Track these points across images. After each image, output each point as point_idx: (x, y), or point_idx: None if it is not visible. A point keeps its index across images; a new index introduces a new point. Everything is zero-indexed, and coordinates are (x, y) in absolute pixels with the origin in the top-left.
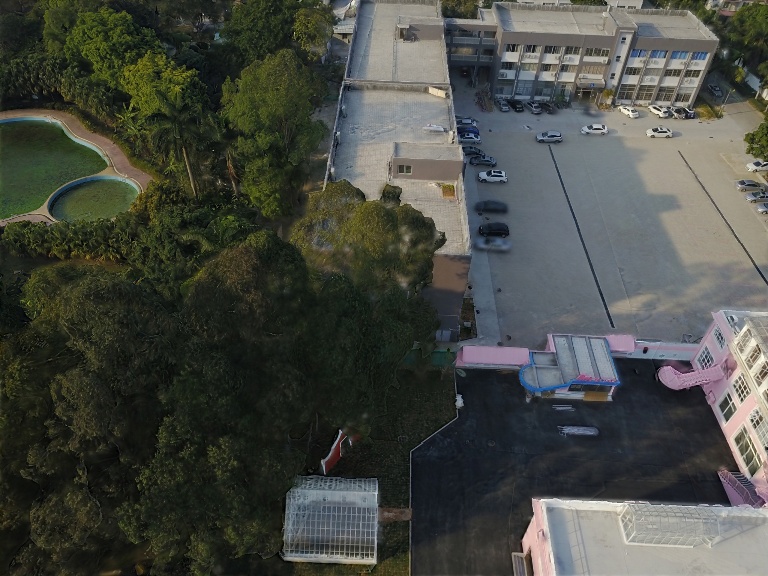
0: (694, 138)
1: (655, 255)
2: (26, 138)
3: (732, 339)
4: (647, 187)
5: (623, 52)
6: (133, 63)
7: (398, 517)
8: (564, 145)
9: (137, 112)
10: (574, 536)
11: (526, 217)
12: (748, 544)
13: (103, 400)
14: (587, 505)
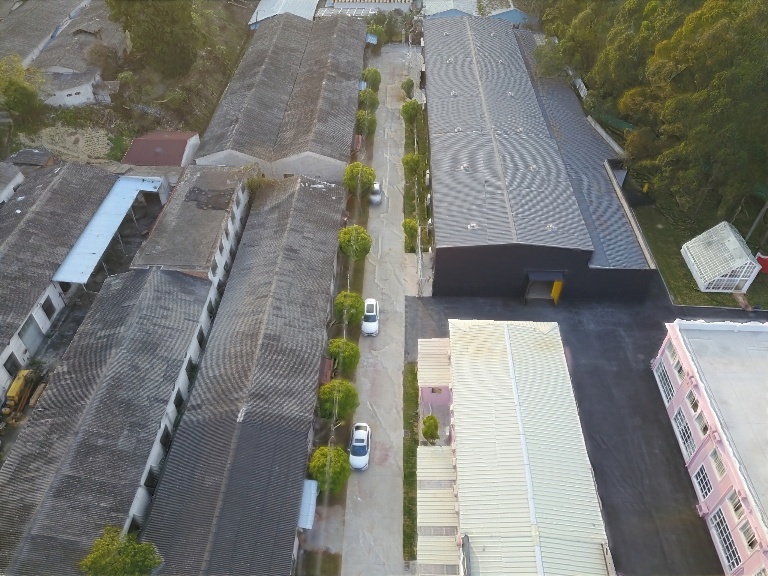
0: None
1: None
2: None
3: None
4: None
5: None
6: None
7: (742, 304)
8: None
9: None
10: None
11: None
12: None
13: (718, 35)
14: None
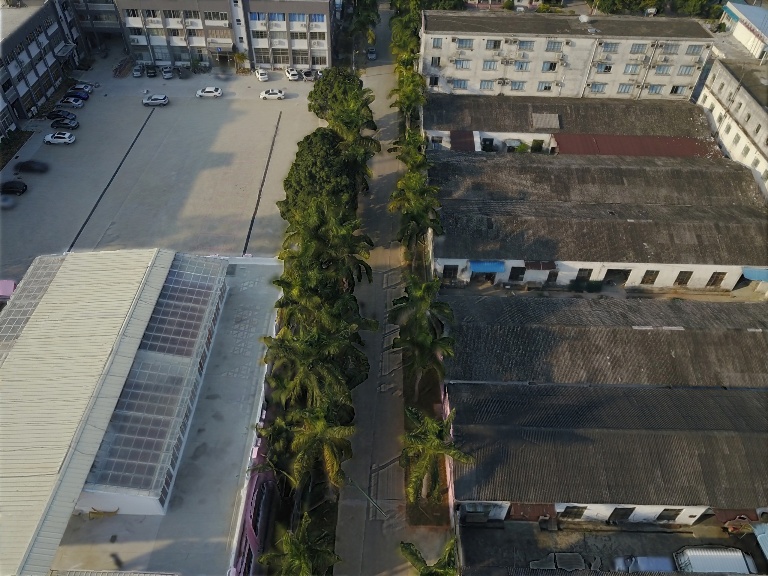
0: None
1: (159, 209)
2: None
3: None
4: (213, 146)
5: (240, 15)
6: None
7: None
8: (168, 108)
9: None
10: None
11: (63, 176)
12: None
13: None
14: None
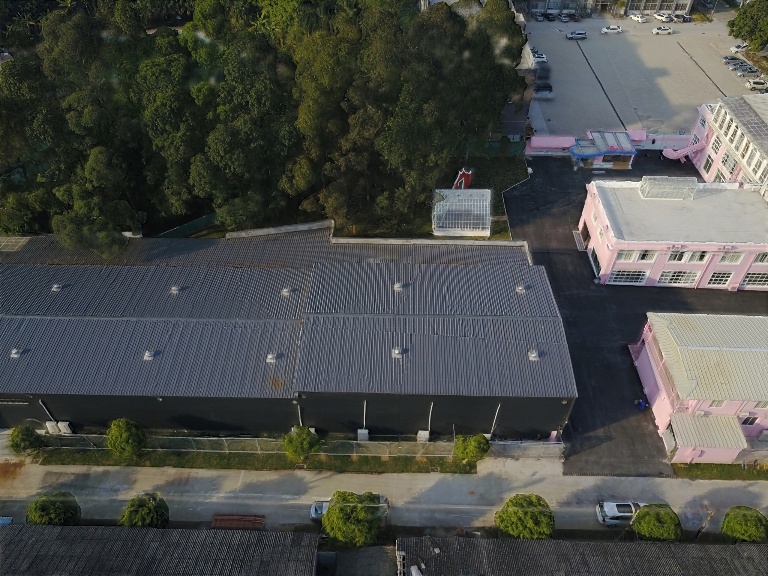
0: (690, 34)
1: (660, 101)
2: None
3: (710, 118)
4: (653, 63)
5: None
6: None
7: (499, 219)
8: (588, 41)
9: (268, 19)
10: (612, 197)
11: (564, 82)
12: (715, 198)
13: None
14: (619, 184)
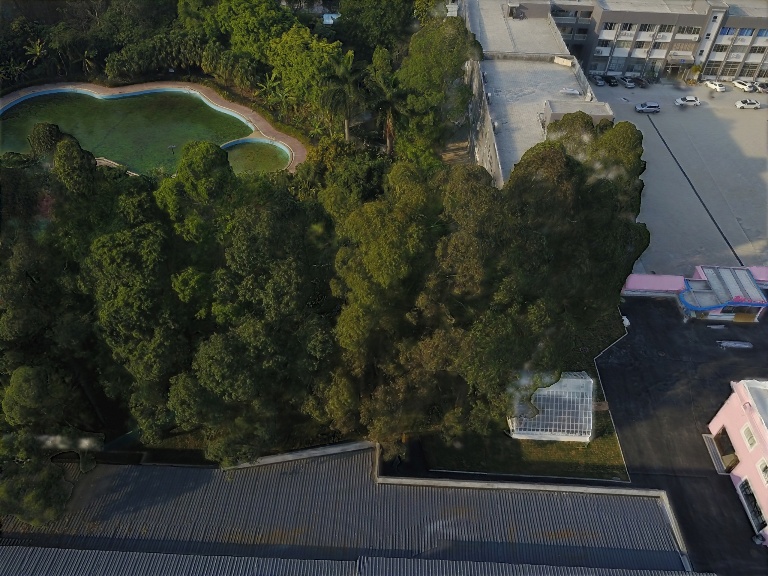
0: None
1: (767, 207)
2: (171, 107)
3: None
4: (746, 151)
5: (713, 30)
6: (278, 36)
7: (597, 408)
8: (662, 115)
9: (279, 81)
10: None
11: (643, 175)
12: None
13: None
14: None
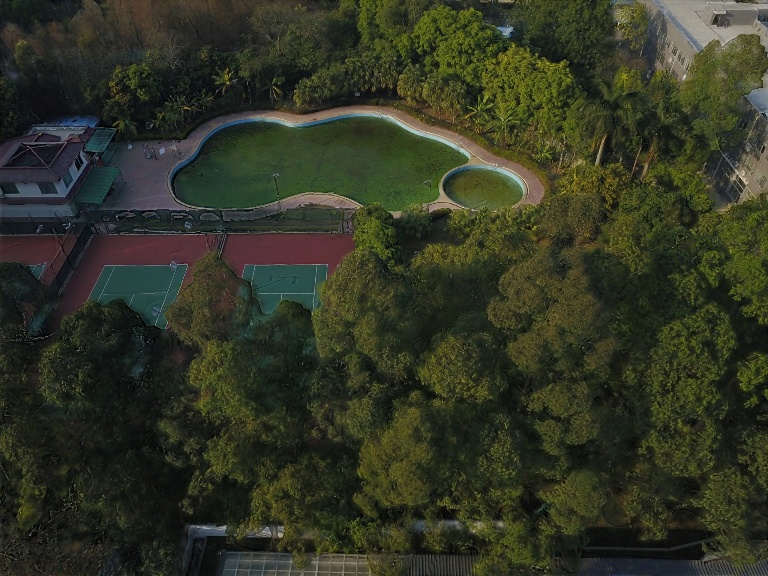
0: None
1: None
2: (369, 133)
3: None
4: None
5: None
6: (493, 57)
7: None
8: None
9: (492, 104)
10: None
11: None
12: None
13: None
14: None
